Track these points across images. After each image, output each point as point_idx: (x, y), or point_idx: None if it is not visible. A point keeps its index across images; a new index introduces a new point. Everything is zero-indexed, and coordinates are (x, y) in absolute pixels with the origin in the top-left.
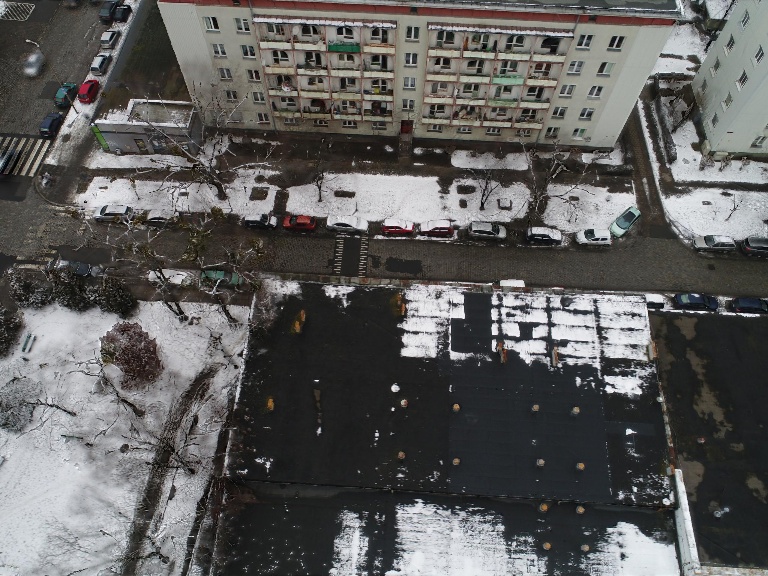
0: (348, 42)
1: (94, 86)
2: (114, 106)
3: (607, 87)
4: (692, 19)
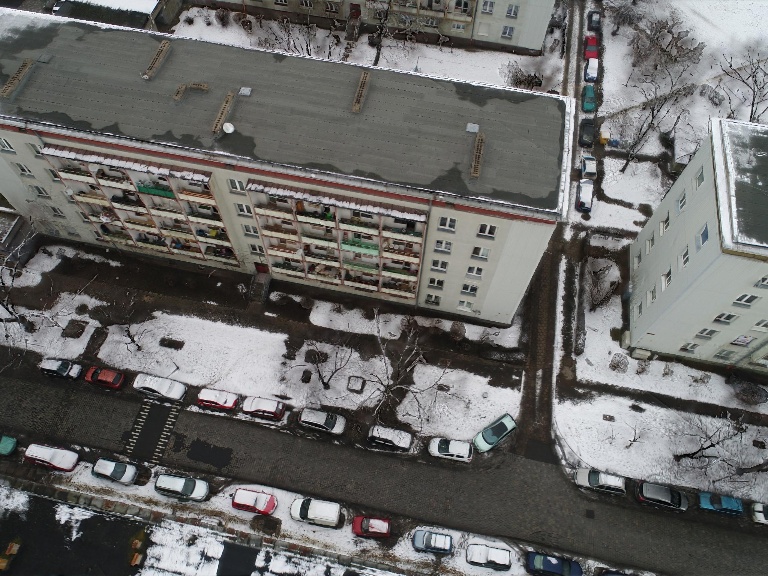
0: (162, 185)
1: None
2: None
3: (487, 270)
4: (658, 155)
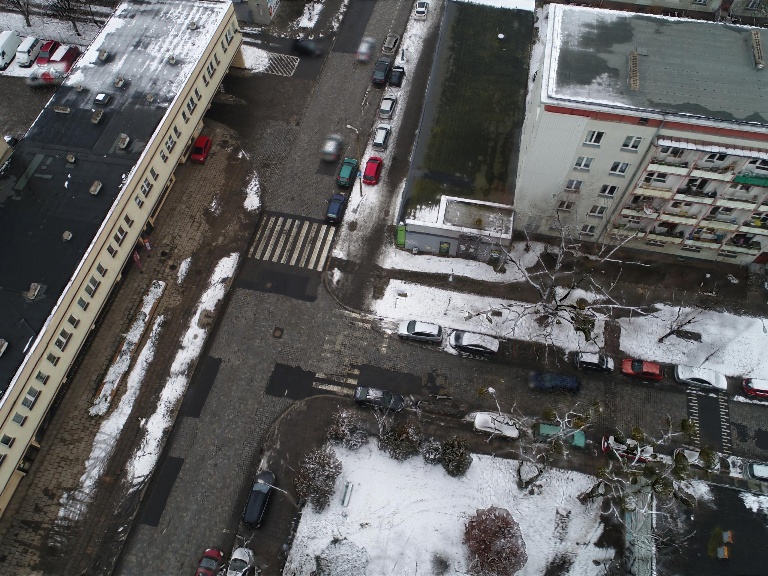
0: (761, 174)
1: (380, 166)
2: (422, 201)
3: None
4: None
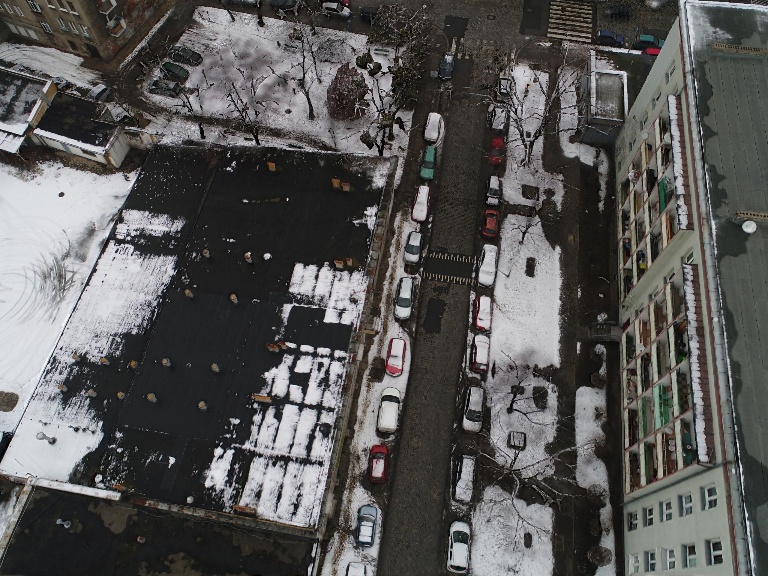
0: None
1: None
2: (618, 63)
3: (675, 573)
4: None
